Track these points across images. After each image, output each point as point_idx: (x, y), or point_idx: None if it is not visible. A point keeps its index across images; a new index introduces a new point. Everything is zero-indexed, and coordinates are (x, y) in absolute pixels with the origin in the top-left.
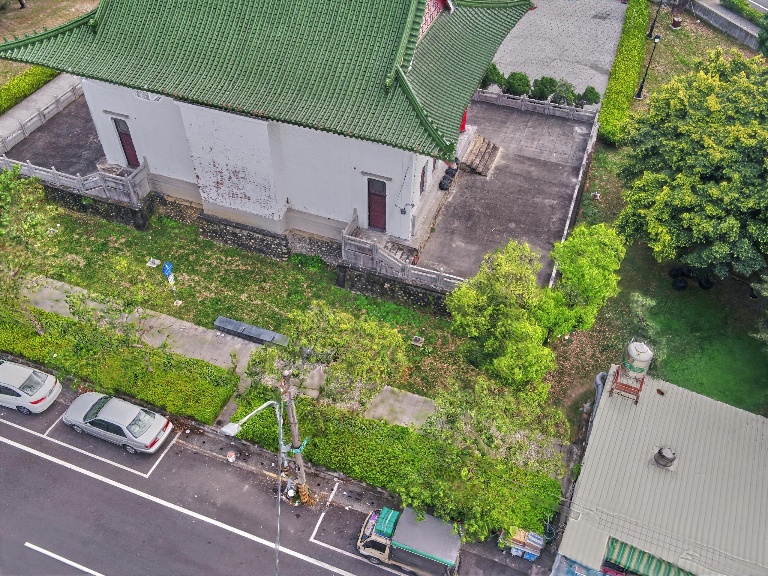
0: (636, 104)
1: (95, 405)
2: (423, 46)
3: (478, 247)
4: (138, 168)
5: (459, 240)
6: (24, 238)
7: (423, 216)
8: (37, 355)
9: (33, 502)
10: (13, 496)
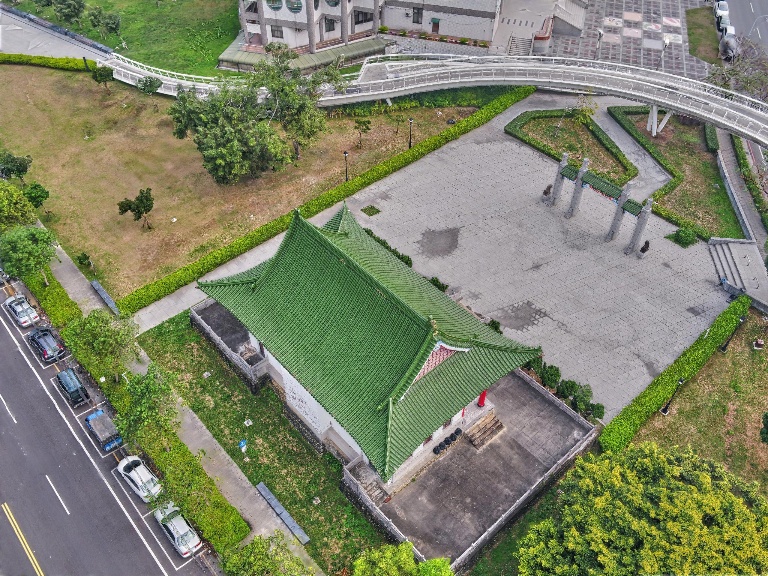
0: (656, 418)
1: (171, 514)
2: (425, 379)
3: (434, 507)
4: (261, 361)
5: (425, 496)
6: (161, 422)
7: (408, 470)
8: (160, 465)
9: (120, 557)
10: (114, 548)
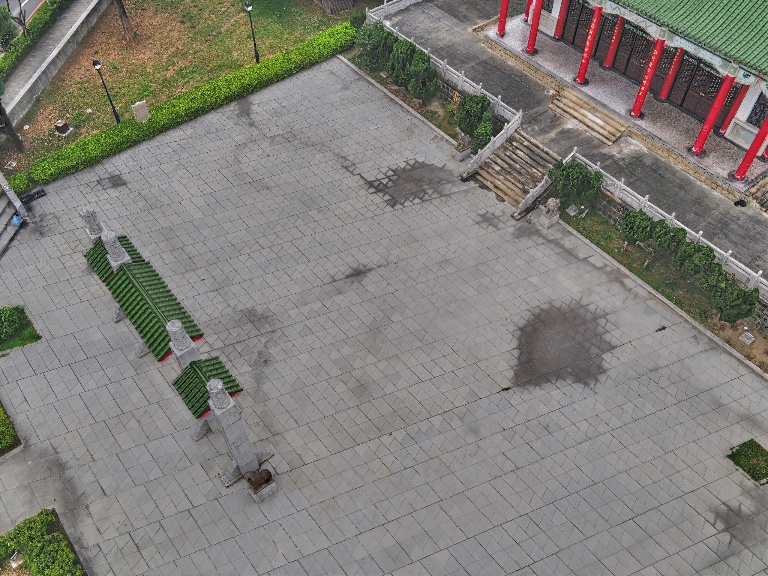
0: None
1: None
2: None
3: None
4: None
5: None
6: None
7: None
8: None
9: None
10: None
